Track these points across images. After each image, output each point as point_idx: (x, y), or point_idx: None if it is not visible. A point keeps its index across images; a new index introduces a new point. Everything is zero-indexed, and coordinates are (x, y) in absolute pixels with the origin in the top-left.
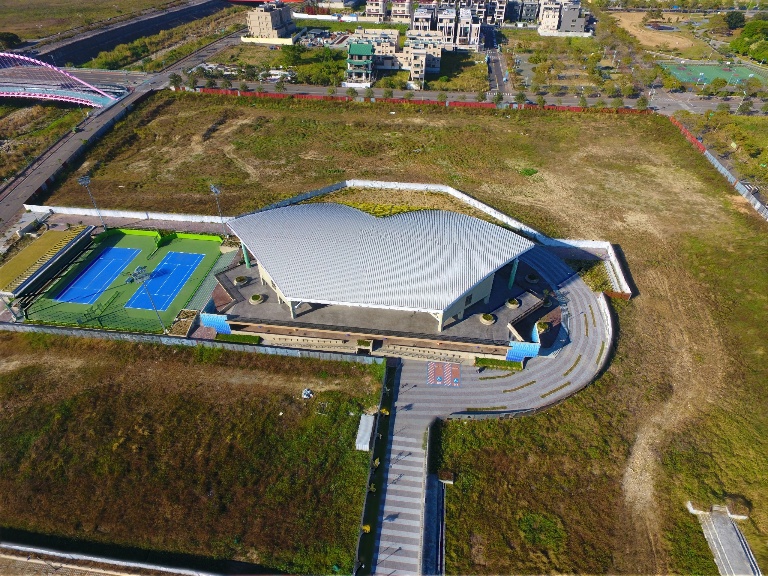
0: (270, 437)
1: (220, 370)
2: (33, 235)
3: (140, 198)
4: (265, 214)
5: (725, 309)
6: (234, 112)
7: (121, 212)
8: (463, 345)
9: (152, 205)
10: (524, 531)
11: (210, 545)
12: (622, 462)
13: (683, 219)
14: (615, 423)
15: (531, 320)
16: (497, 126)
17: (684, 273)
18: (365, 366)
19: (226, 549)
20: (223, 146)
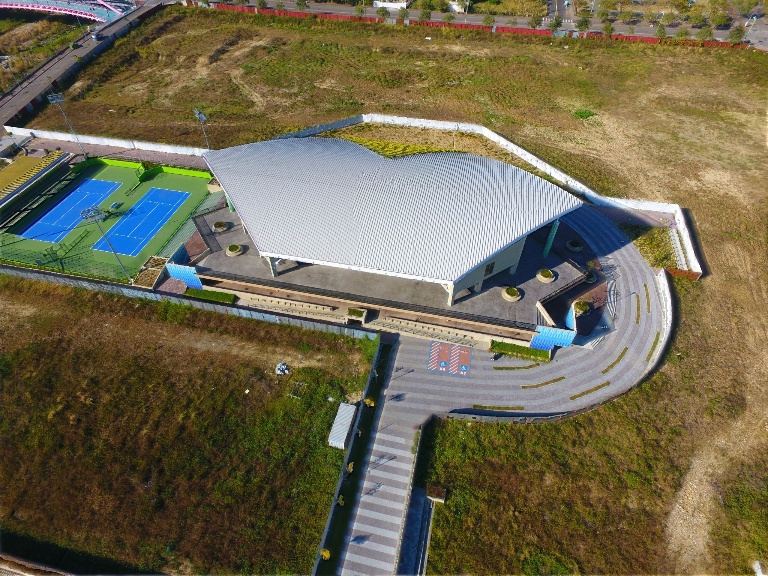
0: (230, 420)
1: (185, 332)
2: (8, 160)
3: (130, 125)
4: (250, 147)
5: None
6: (248, 32)
7: (105, 139)
8: None
9: (141, 133)
10: None
11: (138, 550)
12: (669, 496)
13: None
14: (664, 442)
15: (567, 298)
16: (551, 58)
17: None
18: (355, 341)
19: (155, 558)
20: (231, 70)
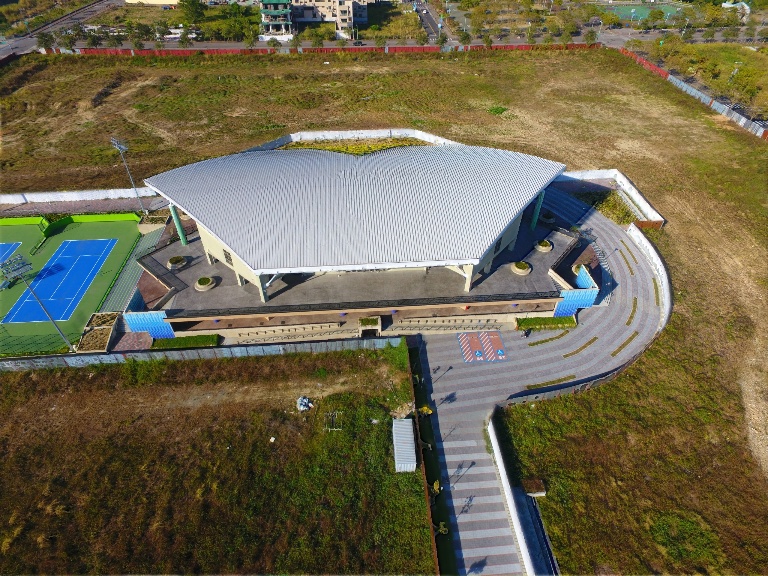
0: (264, 478)
1: (167, 391)
2: None
3: (11, 178)
4: (199, 165)
5: (762, 226)
6: (130, 73)
7: None
8: (497, 305)
9: (30, 185)
10: (663, 544)
11: None
12: (740, 421)
13: (676, 142)
14: (711, 373)
15: (565, 265)
16: (447, 69)
17: (702, 194)
18: (376, 352)
19: None
20: (122, 111)
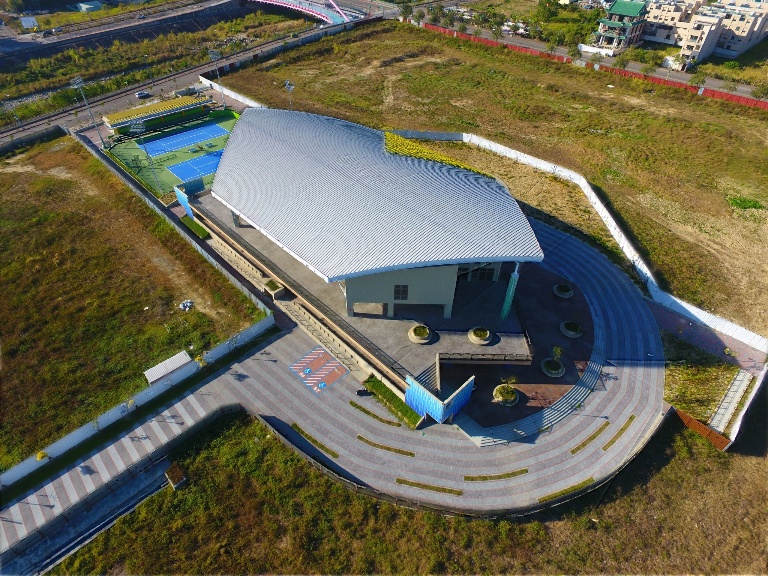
0: (113, 321)
1: (158, 246)
2: None
3: (276, 95)
4: (287, 112)
5: None
6: (434, 49)
7: (247, 99)
8: None
9: (276, 102)
10: None
11: None
12: None
13: None
14: None
15: (503, 377)
16: (757, 135)
17: None
18: (256, 310)
19: None
20: (391, 75)
